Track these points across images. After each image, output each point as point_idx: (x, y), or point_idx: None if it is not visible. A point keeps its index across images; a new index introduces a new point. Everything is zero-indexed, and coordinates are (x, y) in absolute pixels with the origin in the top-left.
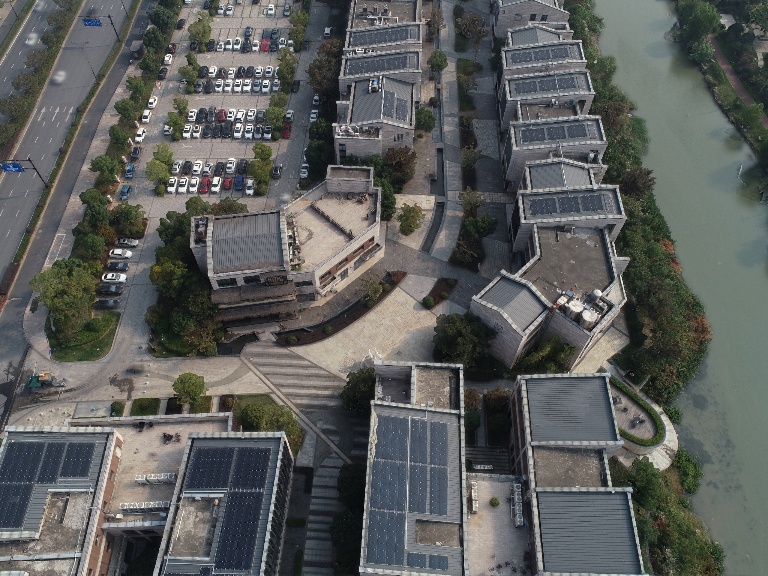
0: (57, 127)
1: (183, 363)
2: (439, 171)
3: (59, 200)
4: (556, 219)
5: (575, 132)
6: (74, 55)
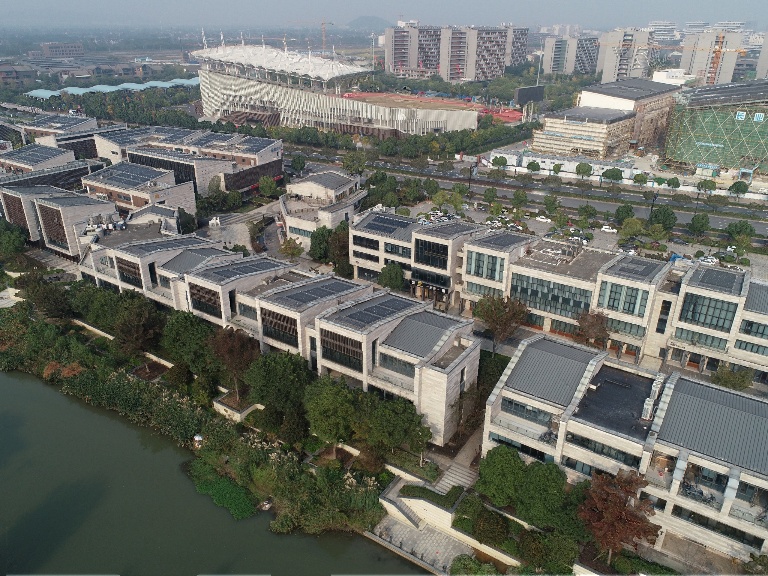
0: (536, 200)
1: None
2: None
3: None
4: (170, 237)
5: (229, 272)
6: (635, 210)
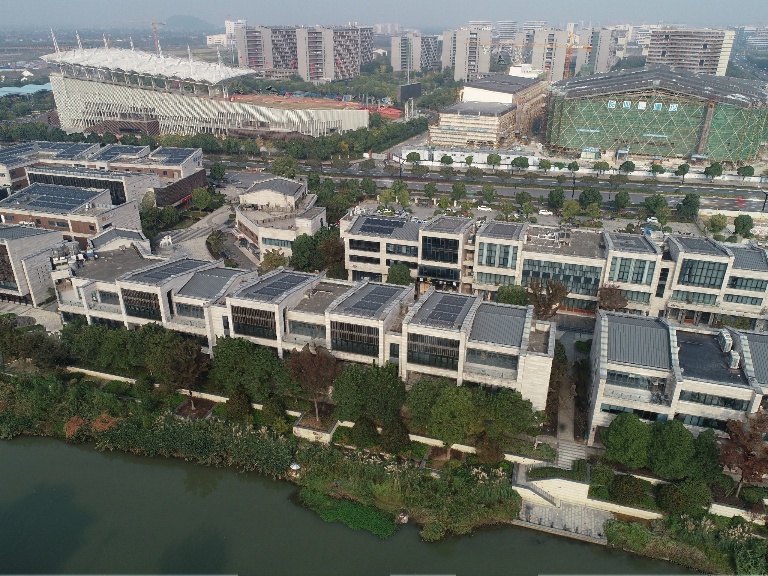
0: None
1: (234, 213)
2: None
3: None
4: (166, 261)
5: (269, 290)
6: None
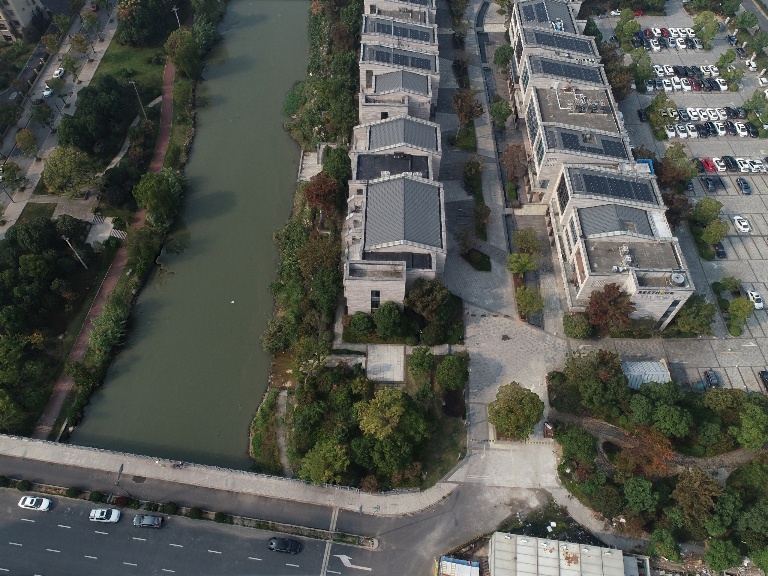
0: None
1: None
2: (483, 50)
3: (766, 27)
4: None
5: None
6: None
